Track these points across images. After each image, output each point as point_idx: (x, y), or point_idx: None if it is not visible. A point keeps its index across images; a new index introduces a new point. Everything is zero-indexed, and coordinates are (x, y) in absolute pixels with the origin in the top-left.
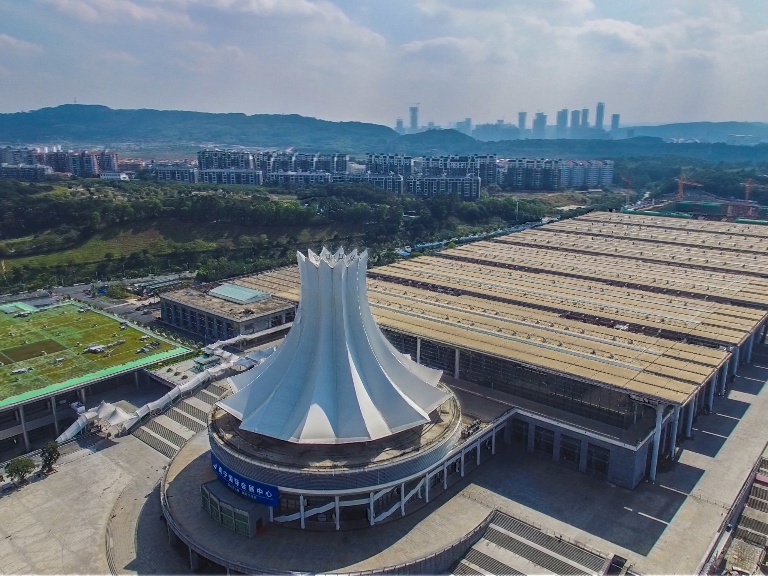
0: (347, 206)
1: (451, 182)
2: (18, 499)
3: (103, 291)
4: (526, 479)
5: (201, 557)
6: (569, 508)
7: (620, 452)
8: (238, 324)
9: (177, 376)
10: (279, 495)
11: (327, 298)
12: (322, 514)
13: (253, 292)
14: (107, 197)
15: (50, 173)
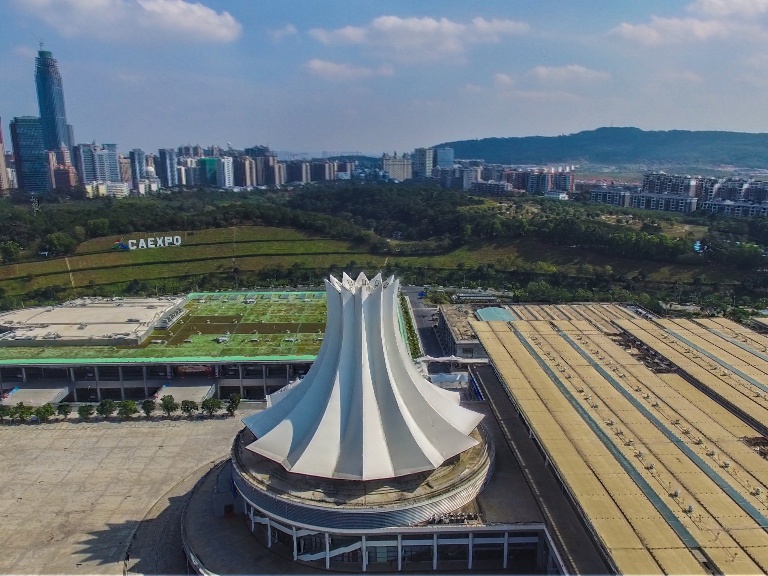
0: (730, 246)
1: None
2: (196, 426)
3: (423, 294)
4: None
5: None
6: None
7: None
8: (456, 345)
9: None
10: (235, 489)
11: (336, 322)
12: None
13: (504, 319)
14: (517, 214)
15: (509, 189)
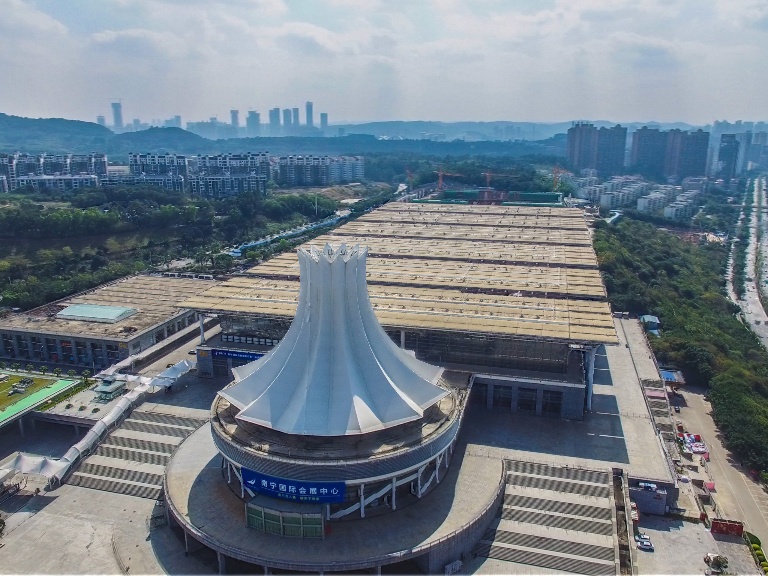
0: (153, 210)
1: (237, 181)
2: None
3: None
4: (505, 430)
5: (281, 572)
6: (553, 444)
7: (571, 392)
8: (126, 344)
9: (84, 411)
10: (346, 489)
11: (342, 292)
12: (376, 499)
13: (118, 308)
14: None
15: None
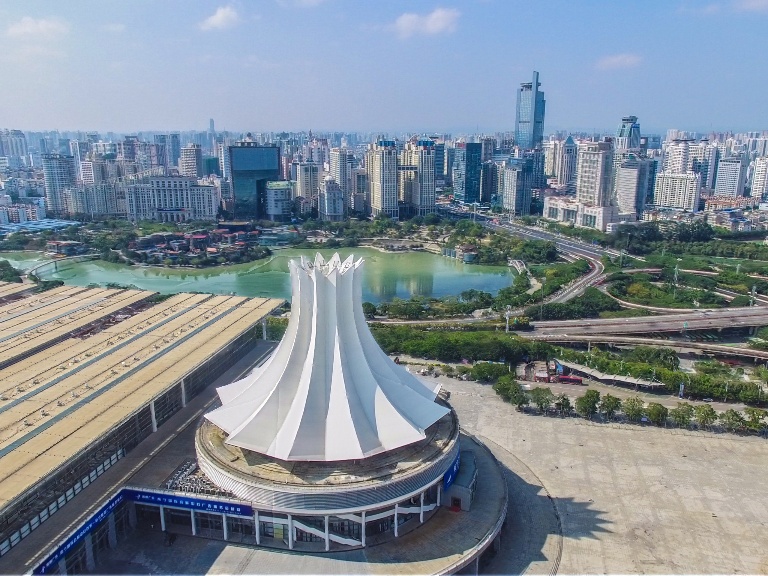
0: None
1: None
2: None
3: None
4: None
5: None
6: None
7: None
8: None
9: None
10: None
11: None
12: None
13: None
14: None
15: None
